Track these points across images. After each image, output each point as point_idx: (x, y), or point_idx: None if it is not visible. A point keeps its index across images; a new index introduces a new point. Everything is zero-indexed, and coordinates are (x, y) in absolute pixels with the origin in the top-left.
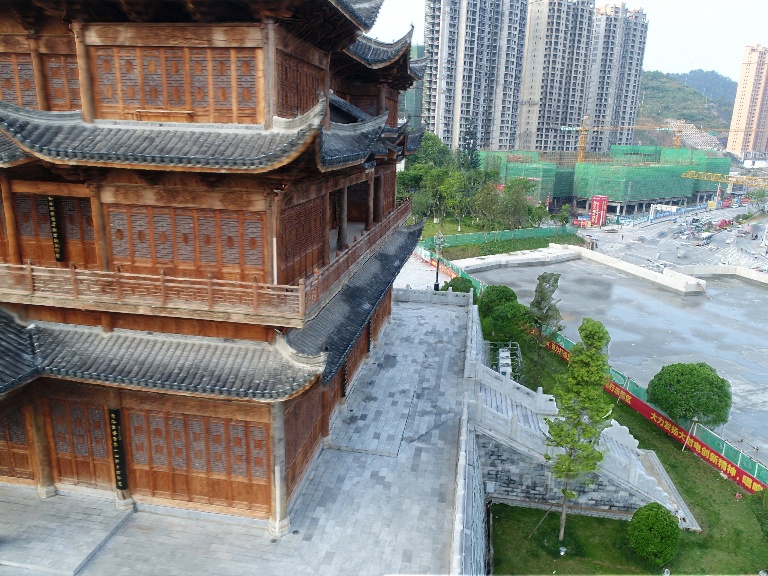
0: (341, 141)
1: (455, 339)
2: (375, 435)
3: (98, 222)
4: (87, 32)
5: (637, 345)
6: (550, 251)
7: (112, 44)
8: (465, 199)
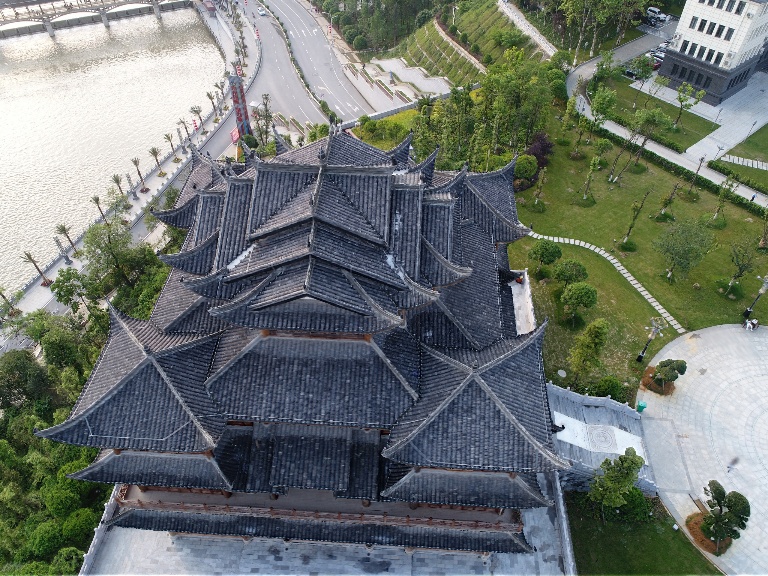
0: (206, 470)
1: None
2: (255, 569)
3: None
4: None
5: None
6: None
7: None
8: None
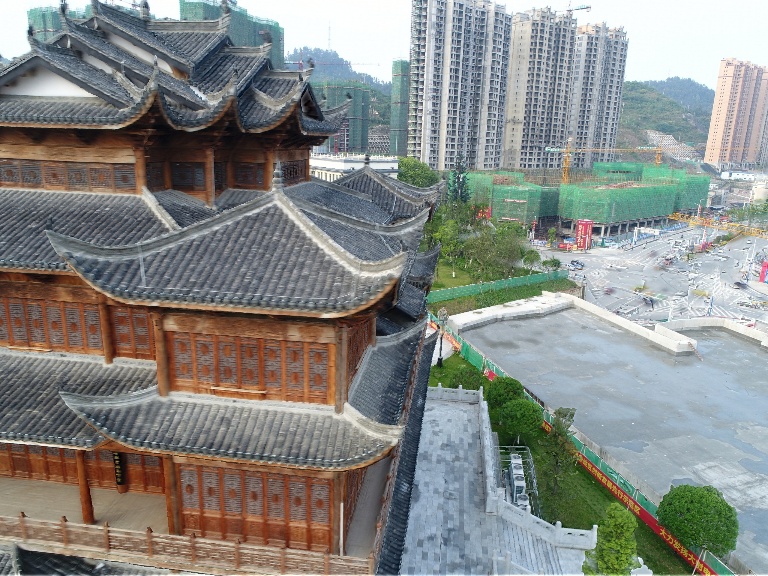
0: (387, 357)
1: (471, 454)
2: None
3: (170, 480)
4: (166, 320)
5: (637, 424)
6: (544, 301)
7: (190, 332)
8: (459, 246)
